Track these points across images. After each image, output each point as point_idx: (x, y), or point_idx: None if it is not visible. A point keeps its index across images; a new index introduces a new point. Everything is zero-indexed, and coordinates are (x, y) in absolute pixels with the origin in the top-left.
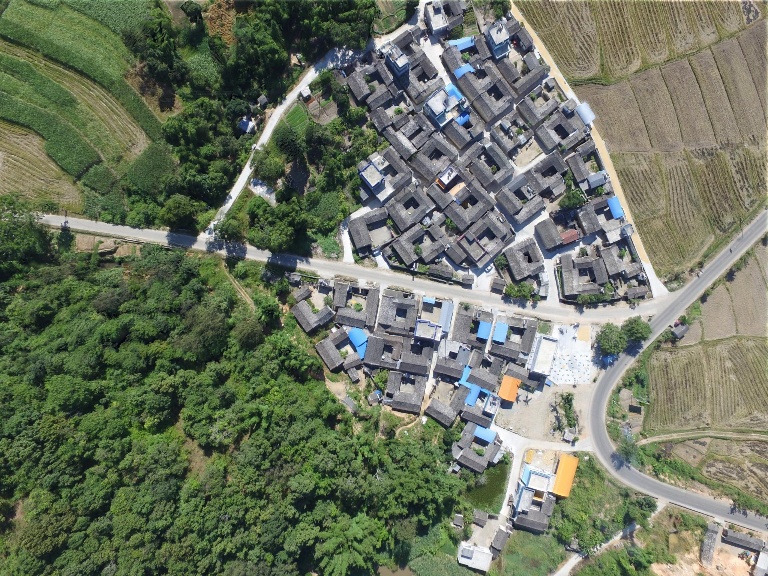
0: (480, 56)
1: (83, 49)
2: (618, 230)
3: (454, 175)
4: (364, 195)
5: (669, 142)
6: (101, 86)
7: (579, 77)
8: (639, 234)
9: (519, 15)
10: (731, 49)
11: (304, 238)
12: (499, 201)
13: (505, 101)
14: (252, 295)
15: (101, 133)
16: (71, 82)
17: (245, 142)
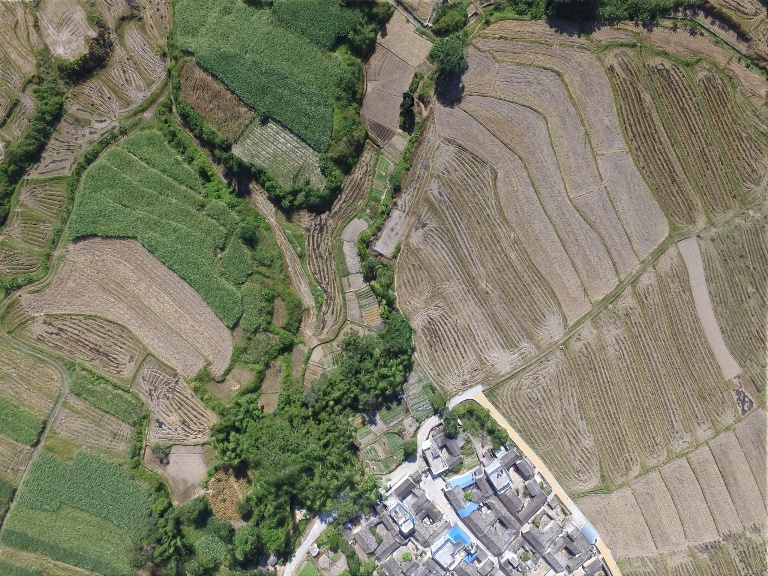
0: (482, 494)
1: (90, 548)
2: None
3: None
4: None
5: (673, 541)
6: None
7: (581, 490)
8: None
9: (516, 437)
10: (728, 442)
11: None
12: None
13: (511, 535)
14: None
15: None
16: None
17: None
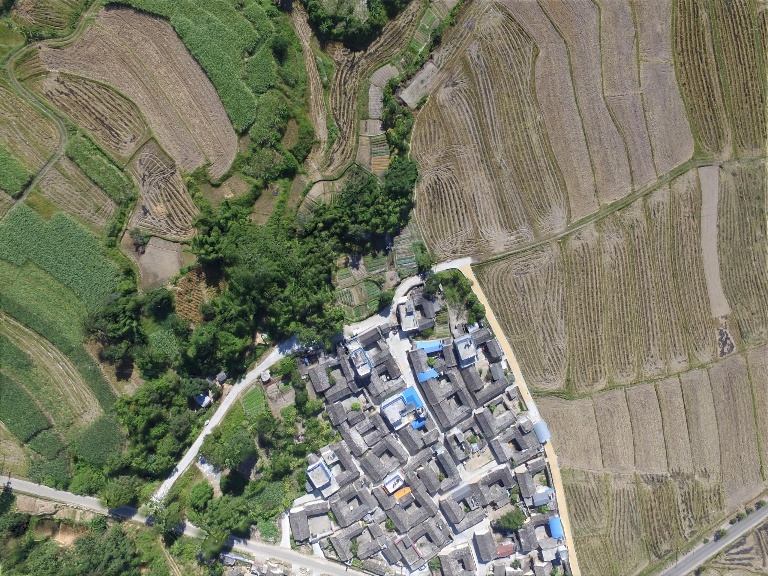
0: (445, 363)
1: (45, 311)
2: (554, 550)
3: (400, 484)
4: (309, 487)
5: (621, 464)
6: (60, 349)
7: (543, 389)
8: (576, 550)
9: (493, 319)
10: (699, 380)
11: (244, 521)
12: (442, 507)
13: (463, 411)
14: (184, 575)
15: (54, 398)
16: (30, 341)
17: (198, 421)
